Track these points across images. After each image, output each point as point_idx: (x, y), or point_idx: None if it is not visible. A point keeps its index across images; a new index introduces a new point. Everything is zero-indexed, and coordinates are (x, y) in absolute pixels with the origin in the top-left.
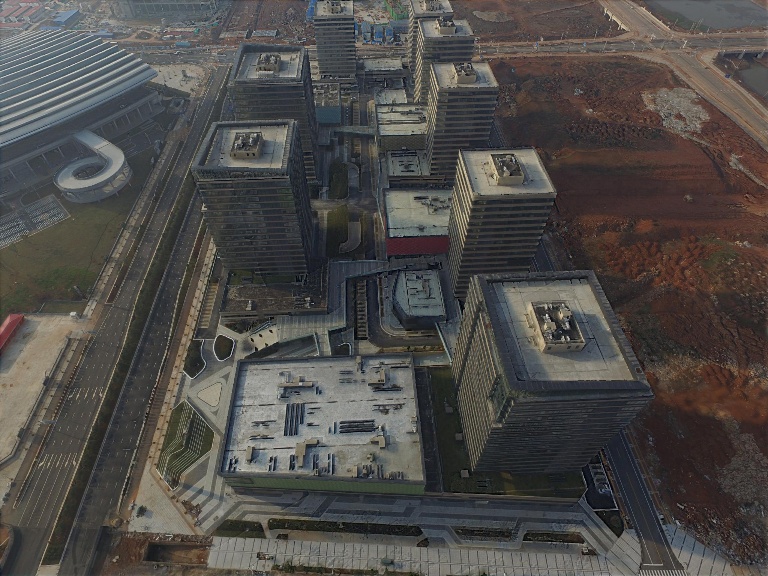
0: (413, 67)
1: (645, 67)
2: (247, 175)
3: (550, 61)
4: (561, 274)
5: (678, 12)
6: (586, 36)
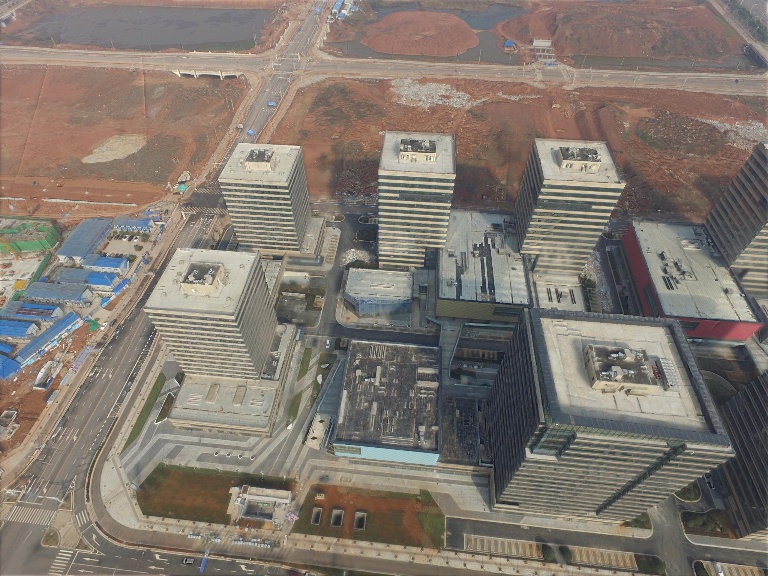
0: (299, 245)
1: (334, 87)
2: None
3: (292, 135)
4: None
5: (207, 41)
6: (238, 99)
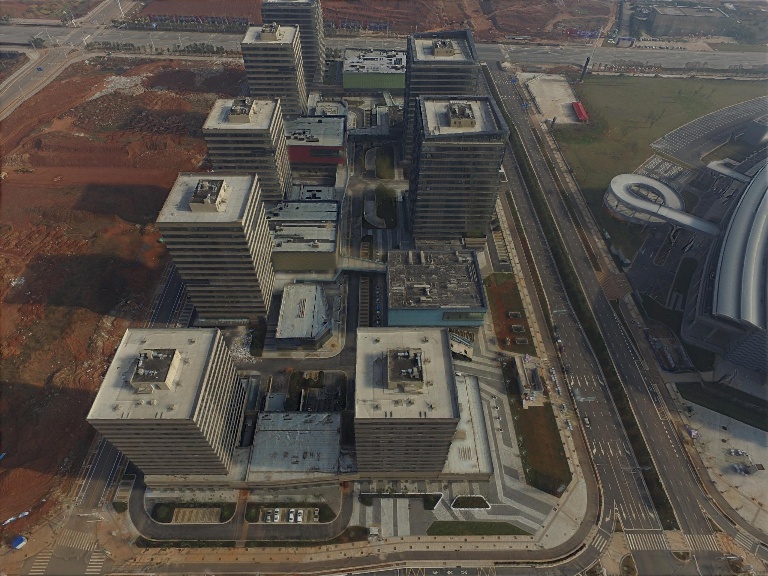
0: None
1: None
2: (435, 37)
3: None
4: (277, 2)
5: None
6: None
